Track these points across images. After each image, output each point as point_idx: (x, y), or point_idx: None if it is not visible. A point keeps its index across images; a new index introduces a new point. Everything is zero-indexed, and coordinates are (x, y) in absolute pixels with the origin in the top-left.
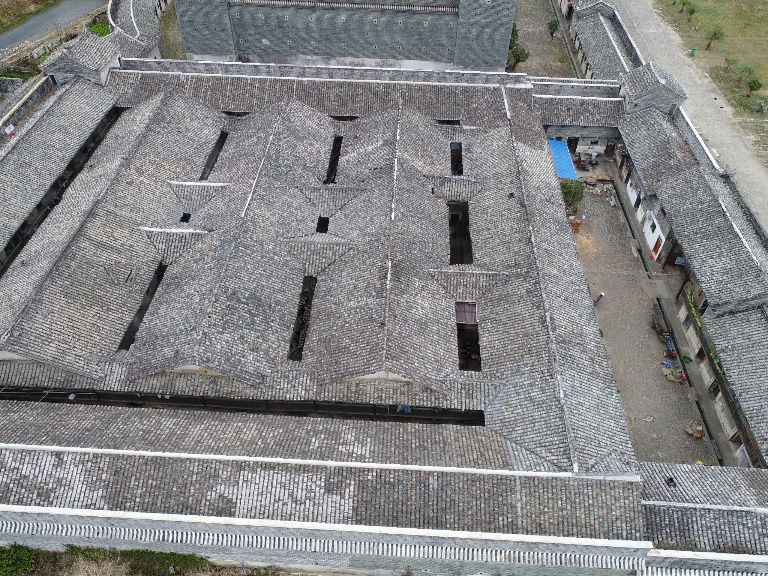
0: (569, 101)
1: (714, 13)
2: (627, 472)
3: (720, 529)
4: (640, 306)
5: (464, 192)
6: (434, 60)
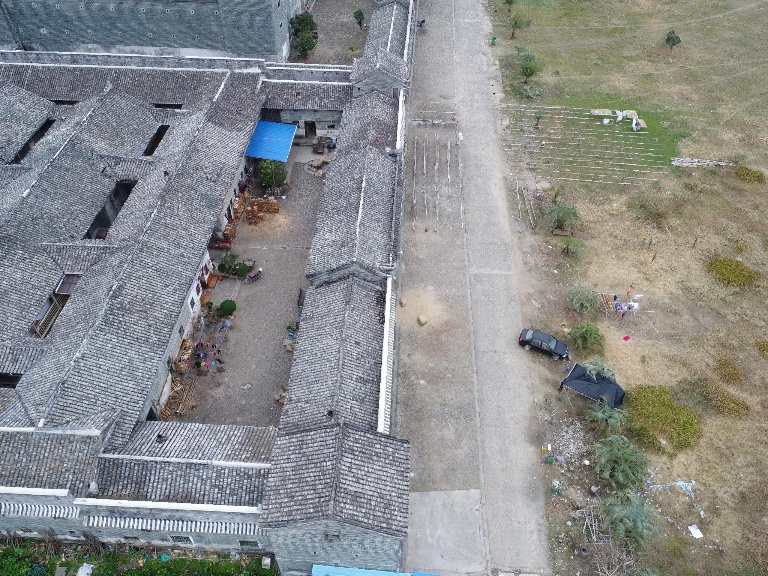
0: (300, 85)
1: (539, 3)
2: (84, 426)
3: (176, 481)
4: (299, 281)
5: (137, 171)
6: (210, 48)
